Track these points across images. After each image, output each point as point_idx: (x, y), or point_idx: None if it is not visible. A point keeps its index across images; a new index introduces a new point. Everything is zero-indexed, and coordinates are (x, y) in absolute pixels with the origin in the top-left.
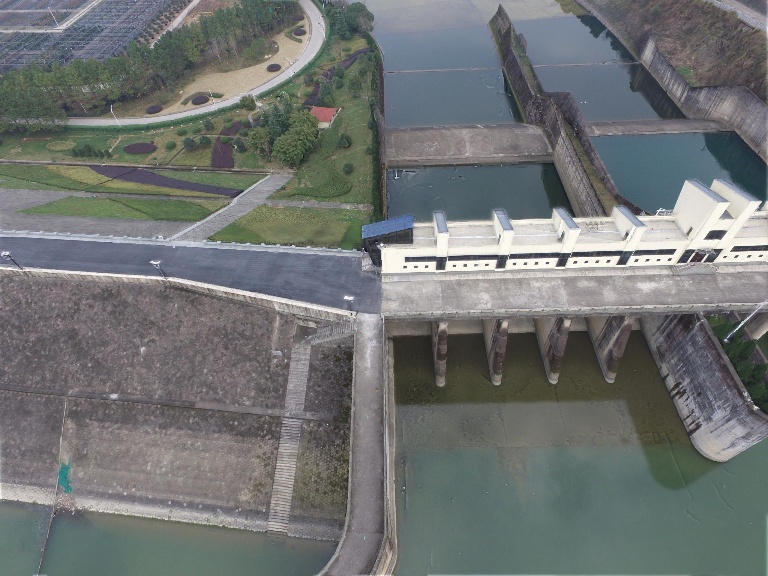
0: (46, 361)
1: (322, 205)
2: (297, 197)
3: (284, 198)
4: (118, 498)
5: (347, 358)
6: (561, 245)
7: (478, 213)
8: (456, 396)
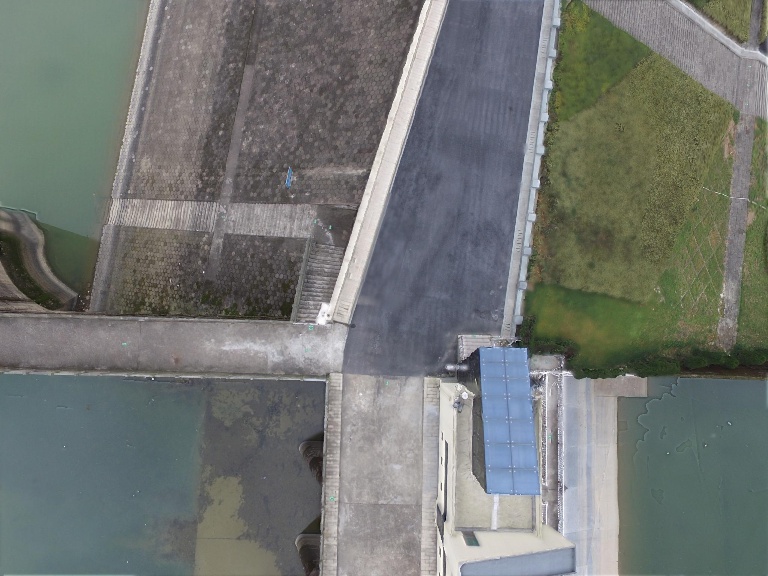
0: None
1: (735, 239)
2: (766, 184)
3: (761, 156)
4: (163, 1)
5: (285, 303)
6: None
7: (730, 566)
8: (282, 471)
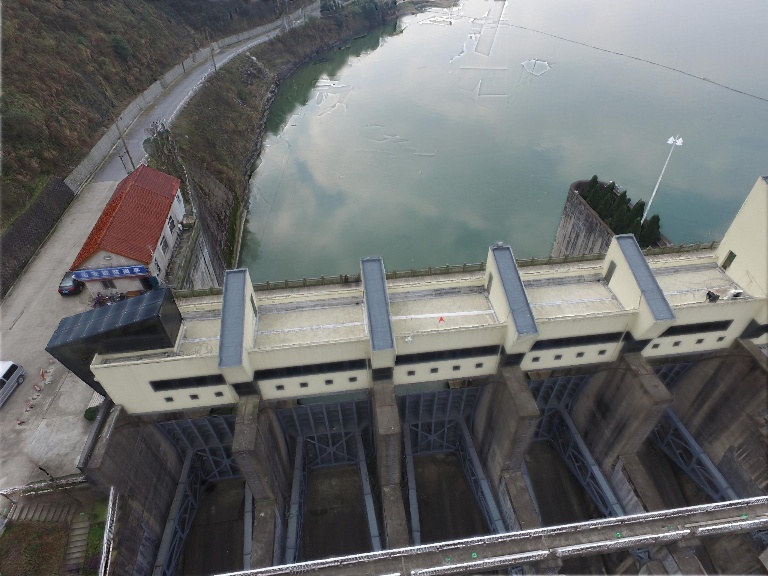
0: None
1: None
2: None
3: None
4: None
5: None
6: None
7: None
8: None
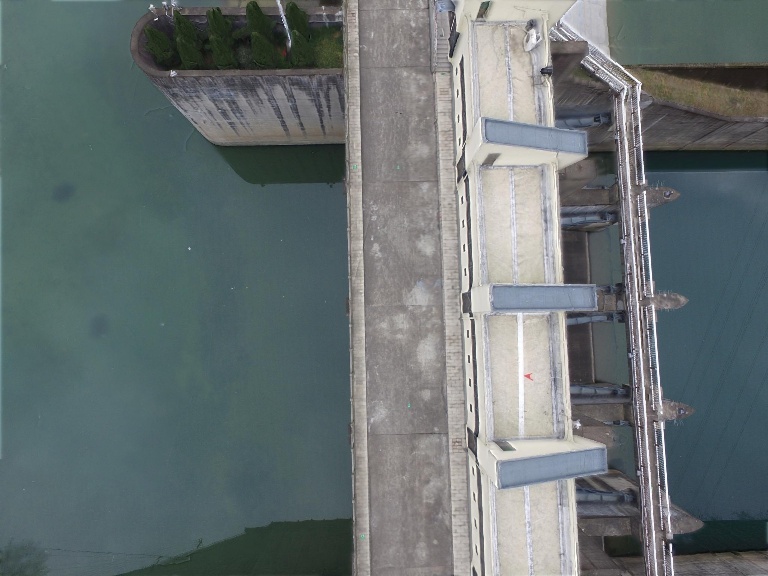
0: None
1: None
2: None
3: None
4: None
5: None
6: None
7: None
8: None
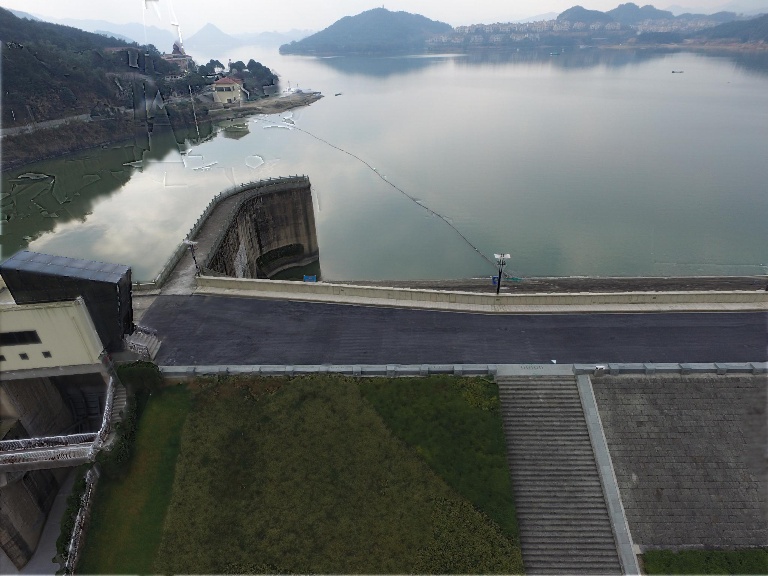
0: (613, 289)
1: None
2: None
3: None
4: None
5: None
6: None
7: None
8: None
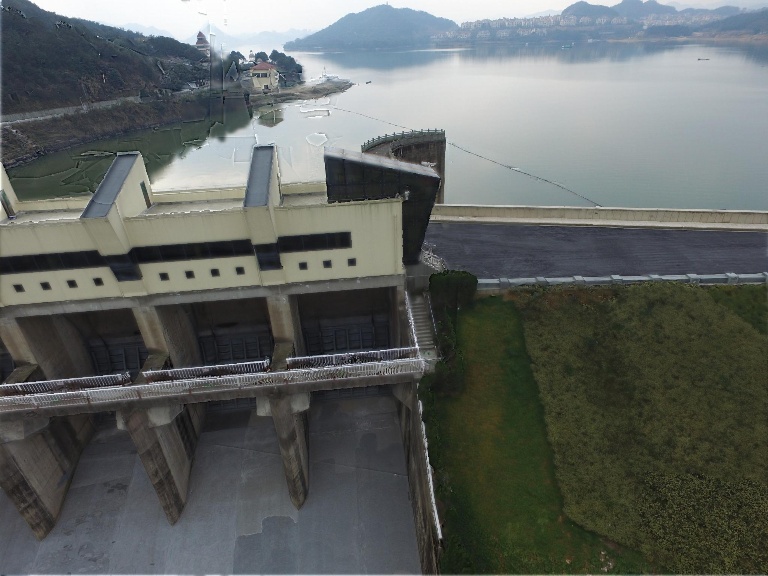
0: None
1: None
2: None
3: None
4: None
5: None
6: (25, 206)
7: None
8: None
